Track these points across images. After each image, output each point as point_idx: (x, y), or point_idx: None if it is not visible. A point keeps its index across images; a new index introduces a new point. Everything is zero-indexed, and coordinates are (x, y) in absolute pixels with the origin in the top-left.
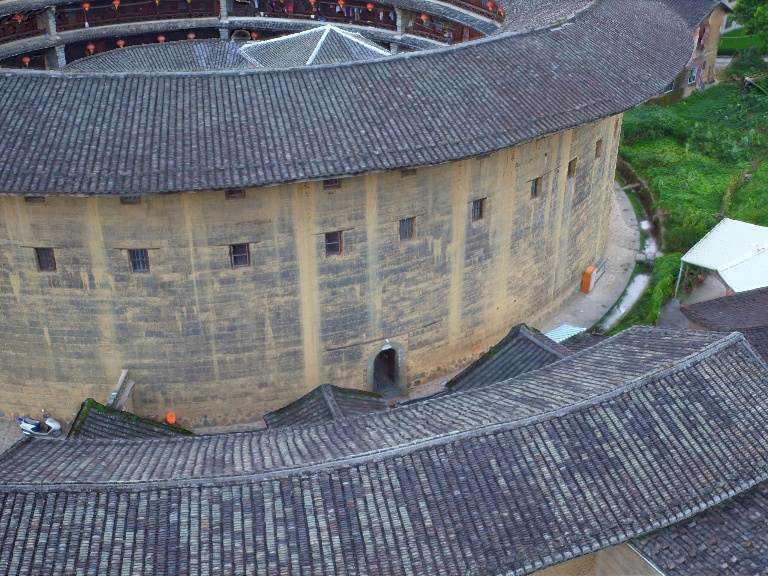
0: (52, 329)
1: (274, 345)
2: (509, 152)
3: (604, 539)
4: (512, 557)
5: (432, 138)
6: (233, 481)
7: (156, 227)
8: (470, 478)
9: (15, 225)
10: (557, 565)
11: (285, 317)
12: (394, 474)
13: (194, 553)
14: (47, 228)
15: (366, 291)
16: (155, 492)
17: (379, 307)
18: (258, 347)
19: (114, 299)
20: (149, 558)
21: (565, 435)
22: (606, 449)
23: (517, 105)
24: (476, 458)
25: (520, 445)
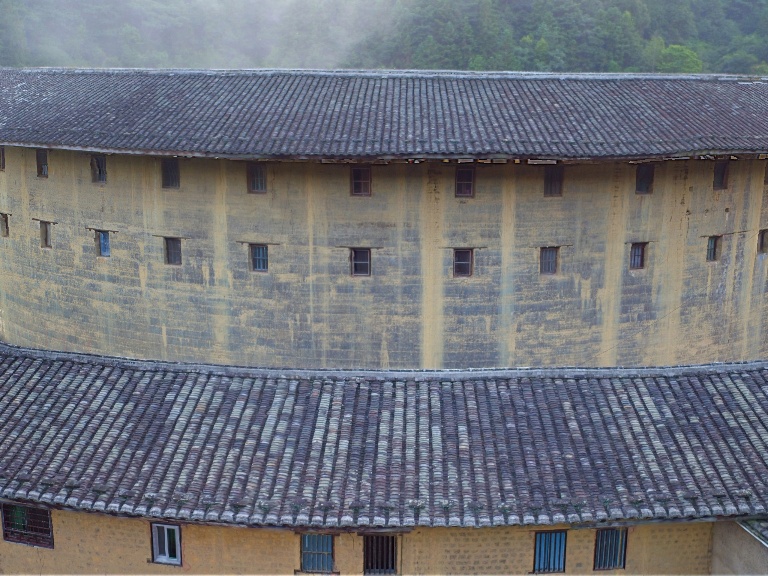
0: (170, 328)
1: None
2: (678, 194)
3: (703, 506)
4: (566, 500)
5: (573, 137)
6: (247, 373)
7: (278, 220)
8: (532, 414)
9: (150, 212)
10: (652, 571)
11: (404, 341)
12: (436, 396)
13: (178, 430)
14: (178, 216)
15: (498, 326)
16: (161, 373)
17: (512, 348)
18: None
19: (231, 298)
20: (128, 427)
21: (671, 395)
22: (726, 417)
23: (681, 125)
24: (546, 398)
25: (607, 394)
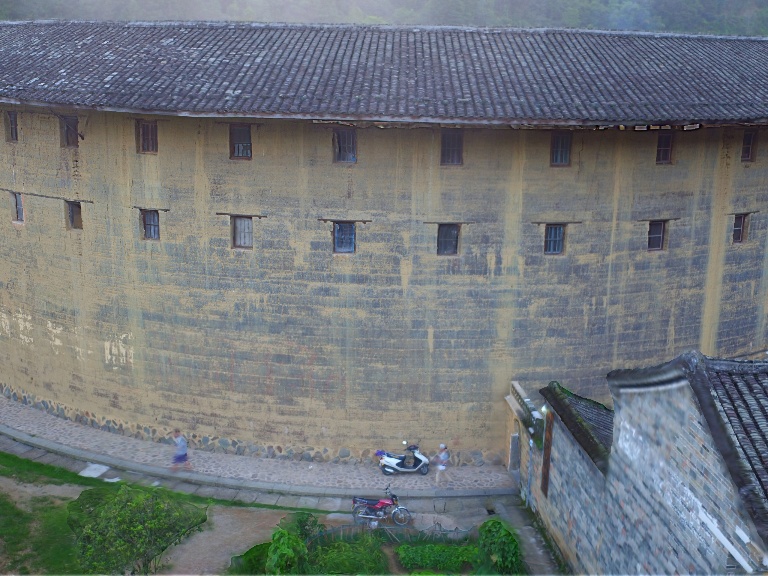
0: (439, 330)
1: (673, 350)
2: None
3: None
4: None
5: None
6: None
7: (583, 195)
8: None
9: (422, 195)
10: None
11: (688, 315)
12: None
13: None
14: (460, 198)
15: (758, 289)
16: None
17: (766, 311)
18: (658, 352)
19: (519, 288)
20: None
21: None
22: None
23: None
24: None
25: None
